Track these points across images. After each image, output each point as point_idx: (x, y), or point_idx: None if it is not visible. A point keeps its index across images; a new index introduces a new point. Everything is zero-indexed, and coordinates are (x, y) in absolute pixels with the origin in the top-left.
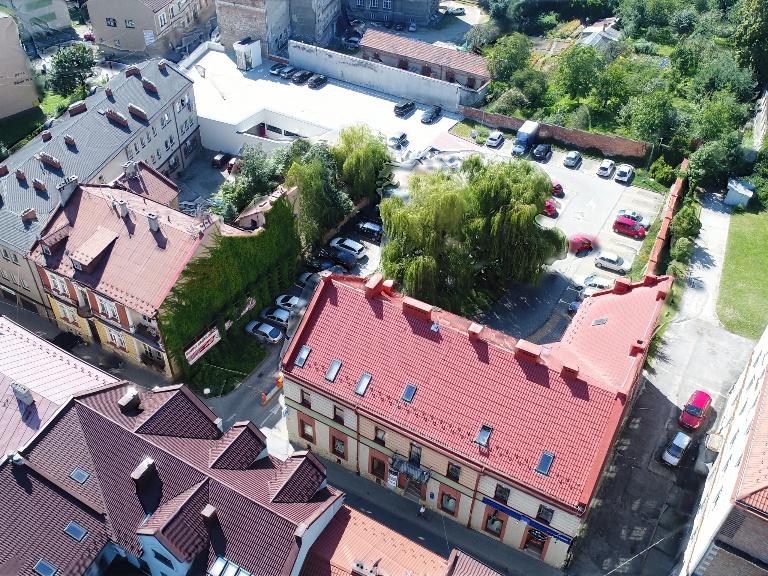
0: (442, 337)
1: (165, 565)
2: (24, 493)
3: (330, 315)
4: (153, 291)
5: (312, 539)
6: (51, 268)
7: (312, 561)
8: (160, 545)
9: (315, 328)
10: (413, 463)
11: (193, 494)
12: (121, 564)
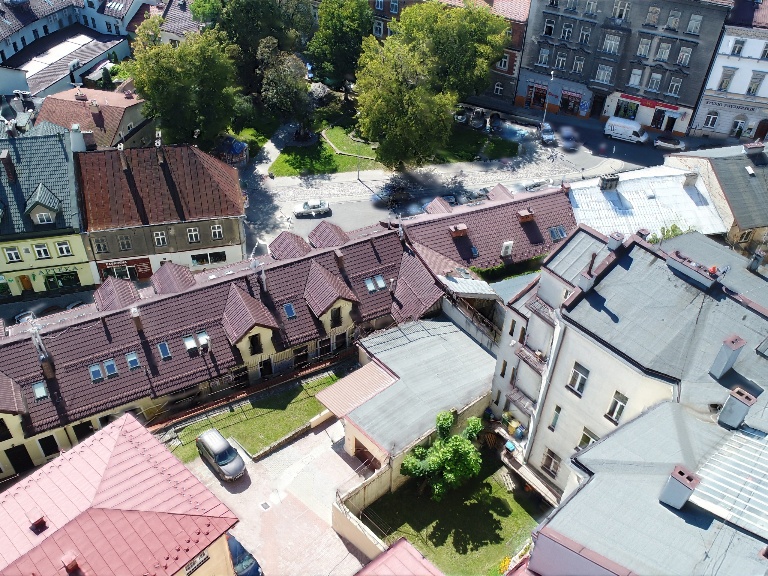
0: None
1: (92, 8)
2: None
3: None
4: None
5: None
6: None
7: (144, 6)
8: None
9: None
10: None
11: None
12: (78, 24)
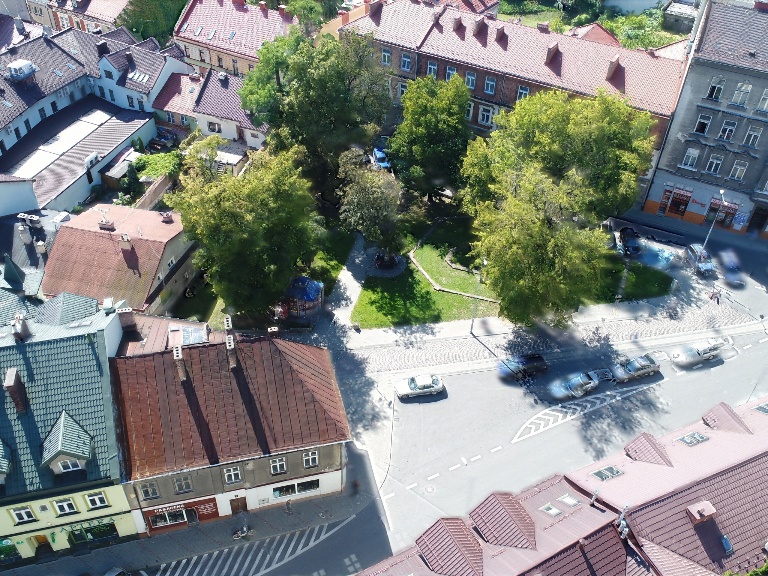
0: (249, 10)
1: (110, 79)
2: (49, 48)
3: (199, 8)
4: (114, 12)
5: (174, 69)
6: (61, 7)
7: (173, 76)
8: (107, 62)
9: (191, 15)
10: (236, 75)
11: (123, 49)
12: (92, 96)
